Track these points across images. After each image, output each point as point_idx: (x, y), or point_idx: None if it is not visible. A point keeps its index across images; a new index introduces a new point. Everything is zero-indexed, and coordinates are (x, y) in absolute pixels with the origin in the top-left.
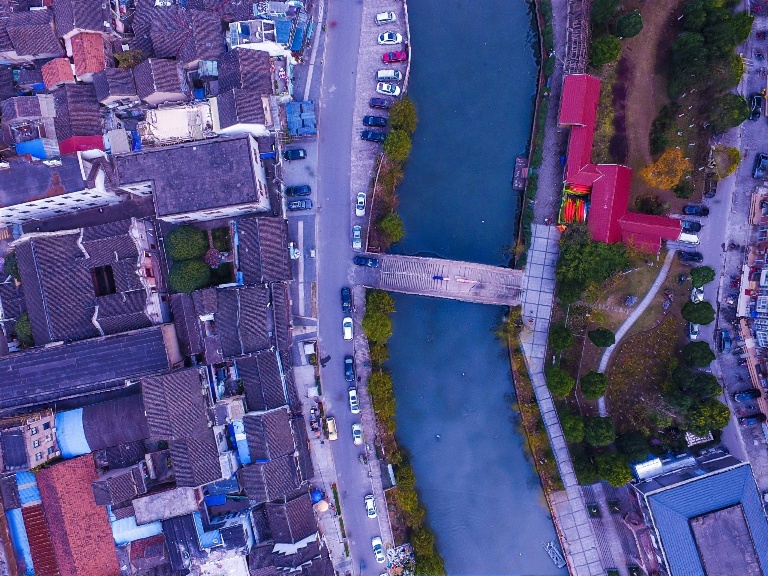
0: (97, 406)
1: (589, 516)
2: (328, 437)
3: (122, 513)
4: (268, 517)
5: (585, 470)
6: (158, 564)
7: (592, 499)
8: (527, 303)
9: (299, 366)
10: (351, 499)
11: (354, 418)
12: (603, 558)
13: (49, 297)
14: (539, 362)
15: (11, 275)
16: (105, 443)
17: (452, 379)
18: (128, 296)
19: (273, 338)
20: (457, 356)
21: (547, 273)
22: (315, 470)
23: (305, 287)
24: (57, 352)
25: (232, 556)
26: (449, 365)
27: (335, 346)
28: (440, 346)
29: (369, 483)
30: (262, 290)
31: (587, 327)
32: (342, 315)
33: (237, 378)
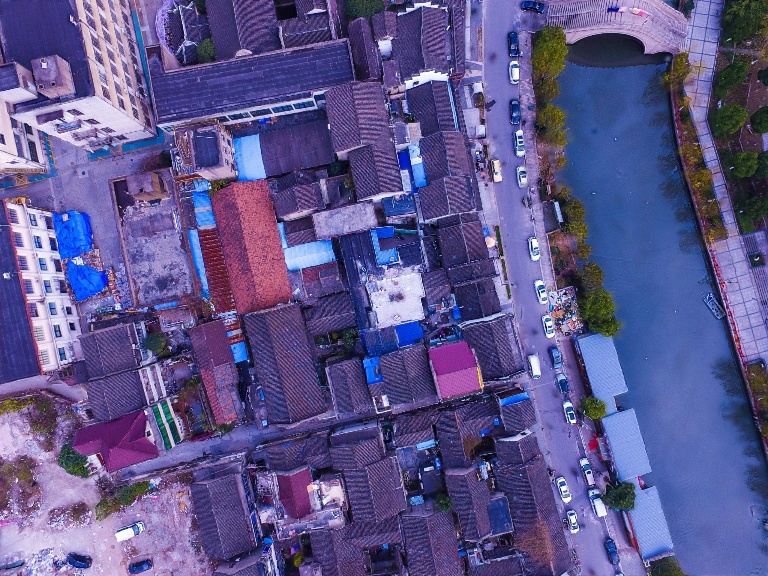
0: (273, 132)
1: (750, 266)
2: (492, 179)
3: (295, 239)
4: (440, 243)
5: (758, 201)
6: (328, 292)
7: (754, 248)
8: (691, 52)
9: (464, 109)
10: (513, 242)
11: (518, 162)
12: (764, 309)
13: (238, 9)
14: (702, 111)
15: (193, 2)
16: (281, 168)
17: (604, 144)
18: (309, 19)
19: (452, 61)
20: (609, 123)
21: (711, 23)
22: (479, 212)
23: (472, 32)
24: (244, 65)
25: (409, 273)
26: (601, 131)
27: (500, 91)
28: (591, 114)
29: (531, 227)
30: (442, 13)
31: (752, 75)
32: (508, 60)
33: (408, 112)
